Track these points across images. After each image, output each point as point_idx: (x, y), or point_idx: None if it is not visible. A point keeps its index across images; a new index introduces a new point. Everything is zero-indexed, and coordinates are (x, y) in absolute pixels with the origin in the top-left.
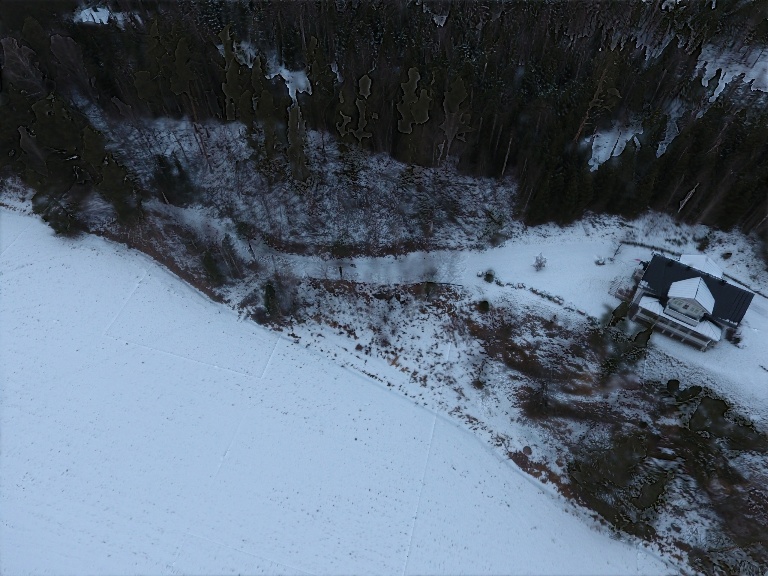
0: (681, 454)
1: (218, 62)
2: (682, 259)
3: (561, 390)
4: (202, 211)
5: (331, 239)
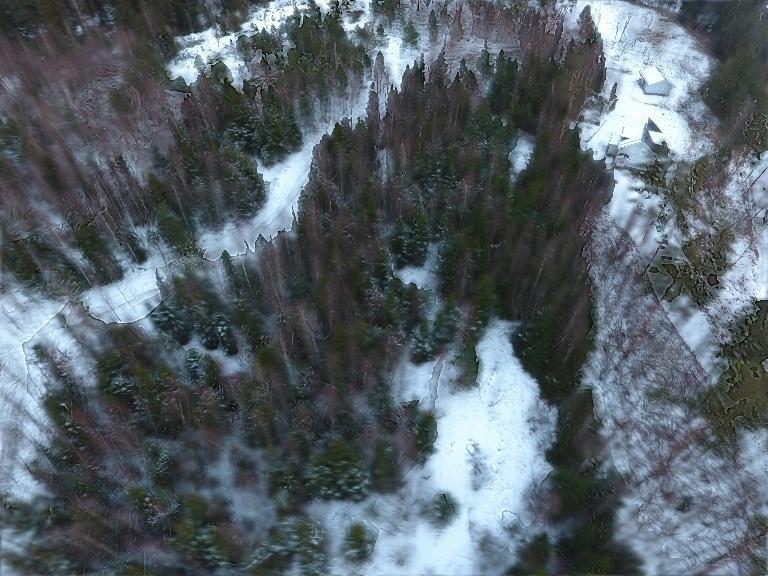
0: (704, 188)
1: (552, 575)
2: (628, 136)
3: (706, 225)
4: (767, 565)
5: (694, 367)
